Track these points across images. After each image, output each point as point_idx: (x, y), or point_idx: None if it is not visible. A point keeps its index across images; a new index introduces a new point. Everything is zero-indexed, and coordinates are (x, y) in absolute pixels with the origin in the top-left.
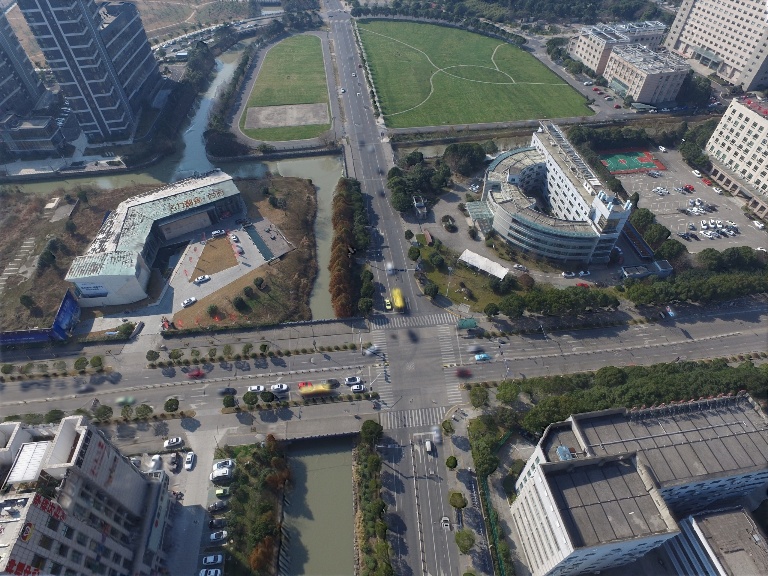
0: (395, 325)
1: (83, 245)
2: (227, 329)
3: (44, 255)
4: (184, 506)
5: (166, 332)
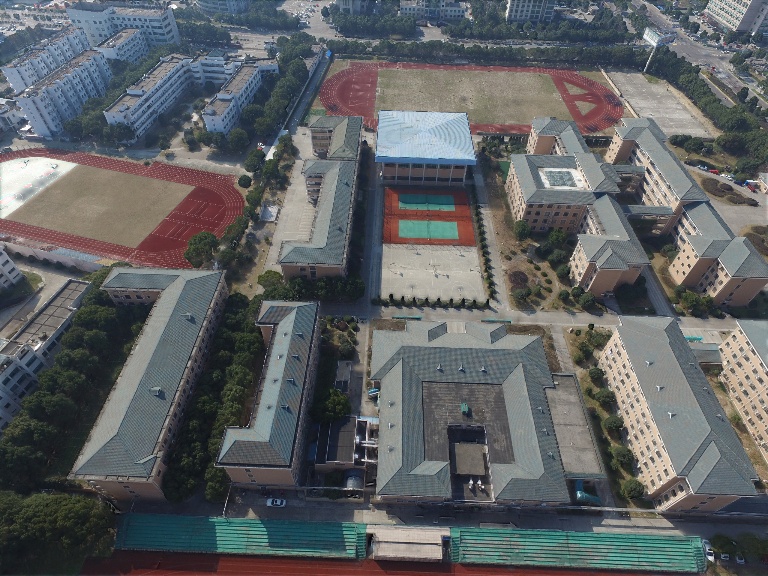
0: None
1: None
2: None
3: None
4: (3, 35)
5: (34, 8)
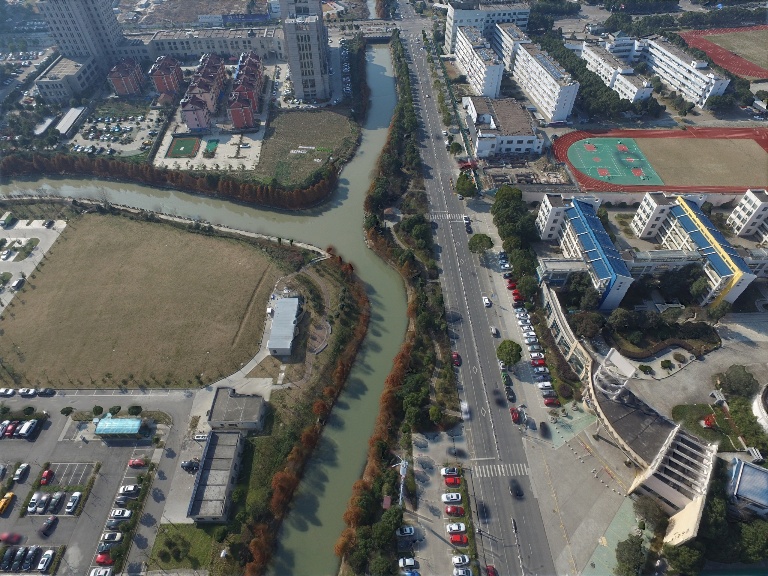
0: (405, 21)
1: (262, 5)
2: (335, 20)
3: (251, 1)
4: (331, 47)
5: None
